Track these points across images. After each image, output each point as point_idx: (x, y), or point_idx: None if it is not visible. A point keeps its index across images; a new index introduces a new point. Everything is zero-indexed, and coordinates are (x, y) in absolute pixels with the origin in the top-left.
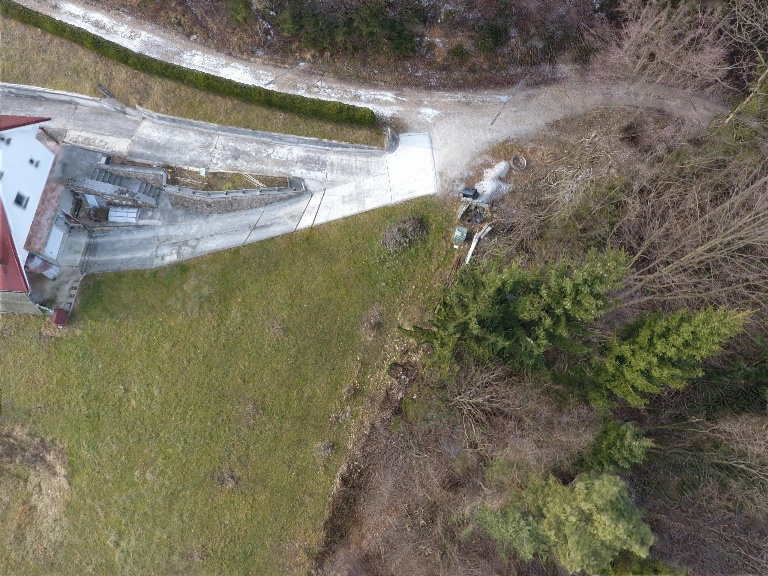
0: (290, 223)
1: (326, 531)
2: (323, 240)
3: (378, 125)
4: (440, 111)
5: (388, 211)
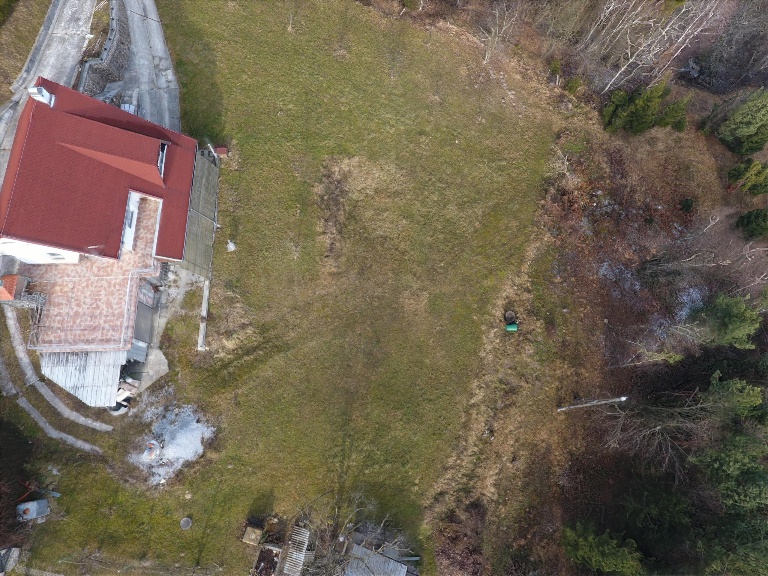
0: None
1: (369, 6)
2: None
3: None
4: None
5: None
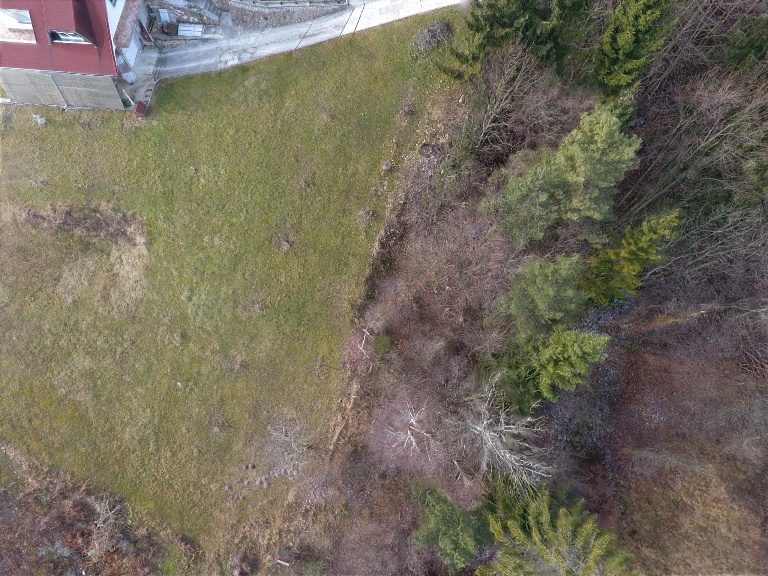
0: (335, 31)
1: (367, 286)
2: (364, 43)
3: None
4: None
5: (419, 18)
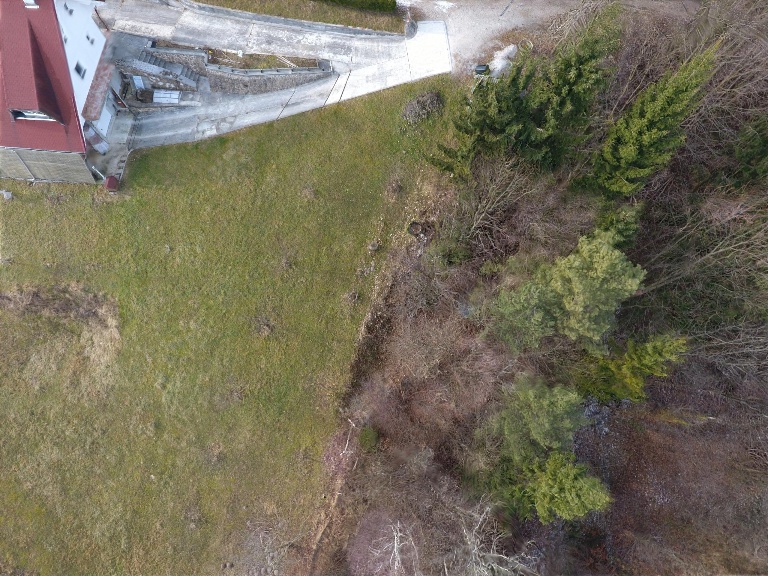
0: (319, 100)
1: (352, 373)
2: (349, 113)
3: (398, 13)
4: (454, 3)
5: (408, 87)
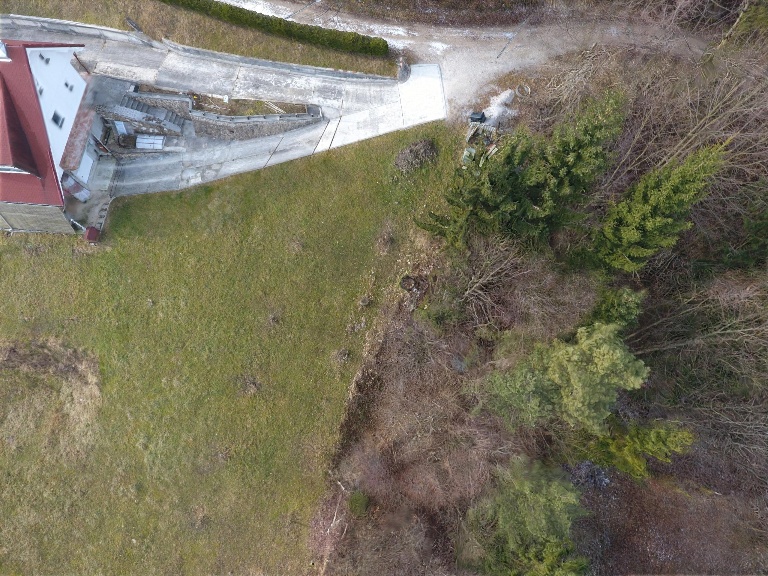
0: (308, 147)
1: (342, 434)
2: (339, 162)
3: (391, 56)
4: (449, 45)
5: (400, 135)
